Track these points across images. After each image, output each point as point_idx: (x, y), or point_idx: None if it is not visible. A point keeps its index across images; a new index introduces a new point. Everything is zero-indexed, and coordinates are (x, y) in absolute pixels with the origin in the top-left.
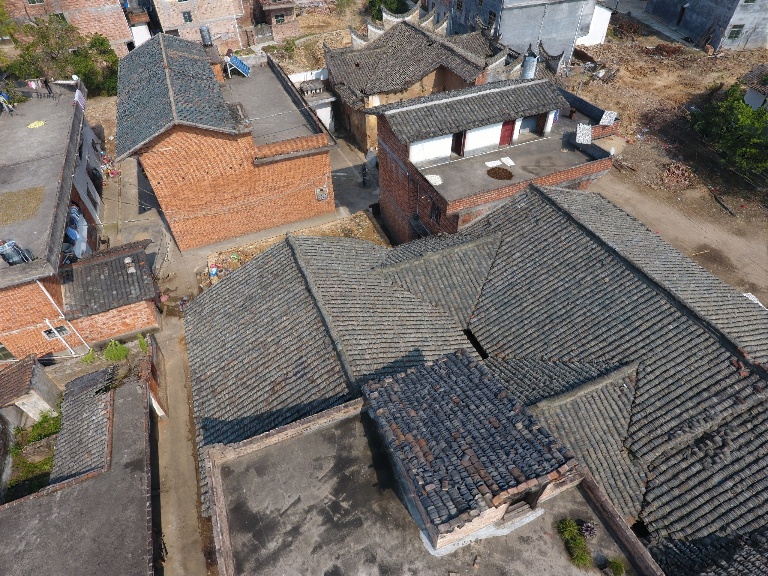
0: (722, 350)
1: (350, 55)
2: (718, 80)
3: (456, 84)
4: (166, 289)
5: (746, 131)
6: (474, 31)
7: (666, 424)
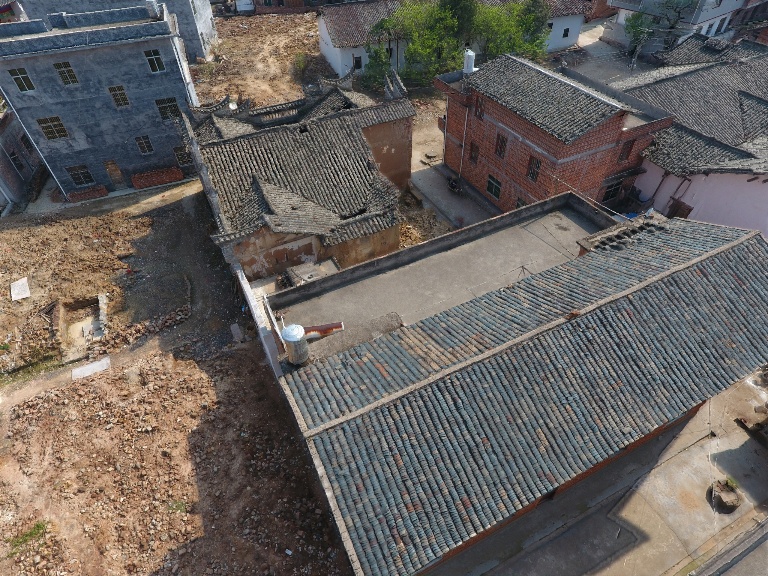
0: (725, 67)
1: (274, 208)
2: (271, 67)
3: (379, 135)
4: (759, 410)
5: (425, 57)
6: (195, 123)
7: (761, 93)
